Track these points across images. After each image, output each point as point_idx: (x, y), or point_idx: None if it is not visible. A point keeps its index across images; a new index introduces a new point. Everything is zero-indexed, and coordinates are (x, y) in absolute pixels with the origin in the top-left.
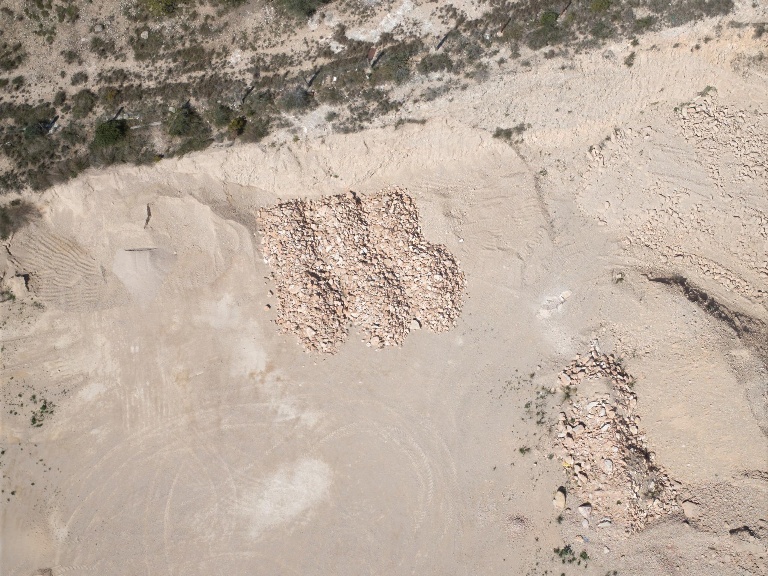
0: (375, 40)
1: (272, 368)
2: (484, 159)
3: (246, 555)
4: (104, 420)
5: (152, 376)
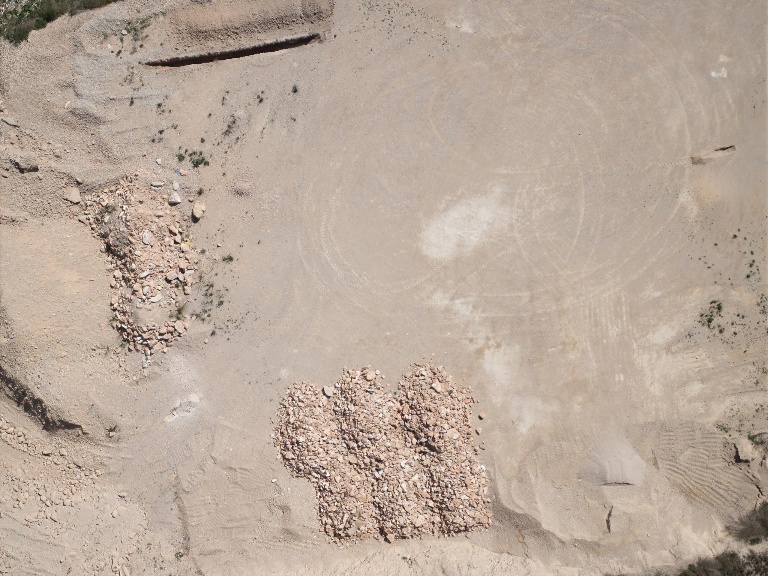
0: None
1: (478, 352)
2: (242, 572)
3: (504, 170)
4: (648, 305)
5: (601, 348)
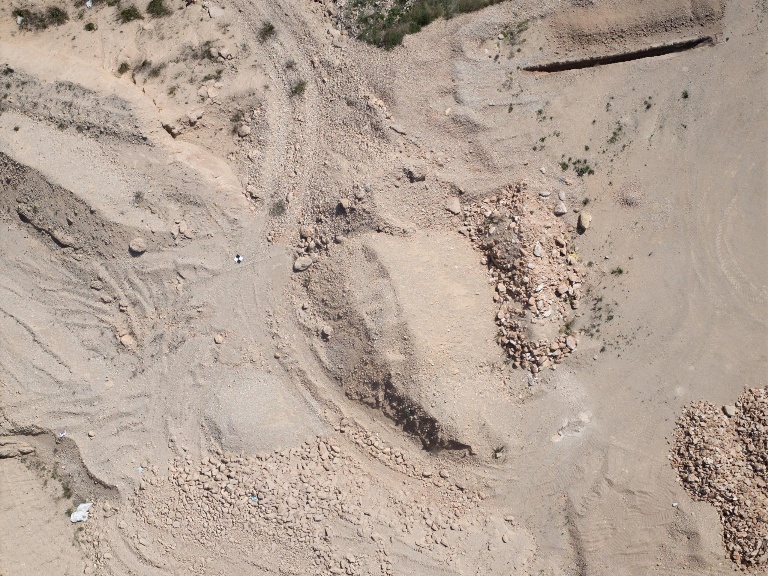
0: None
1: None
2: None
3: None
4: None
5: None
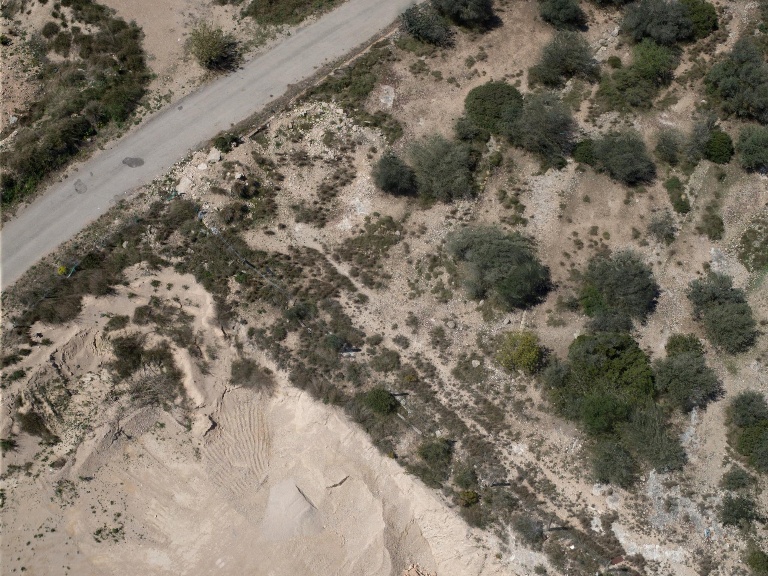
0: (629, 552)
1: None
2: None
3: None
4: None
5: None
